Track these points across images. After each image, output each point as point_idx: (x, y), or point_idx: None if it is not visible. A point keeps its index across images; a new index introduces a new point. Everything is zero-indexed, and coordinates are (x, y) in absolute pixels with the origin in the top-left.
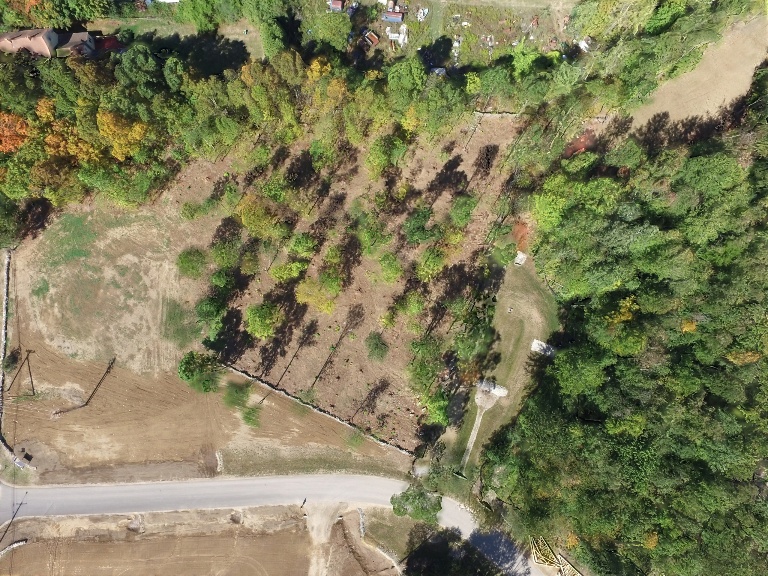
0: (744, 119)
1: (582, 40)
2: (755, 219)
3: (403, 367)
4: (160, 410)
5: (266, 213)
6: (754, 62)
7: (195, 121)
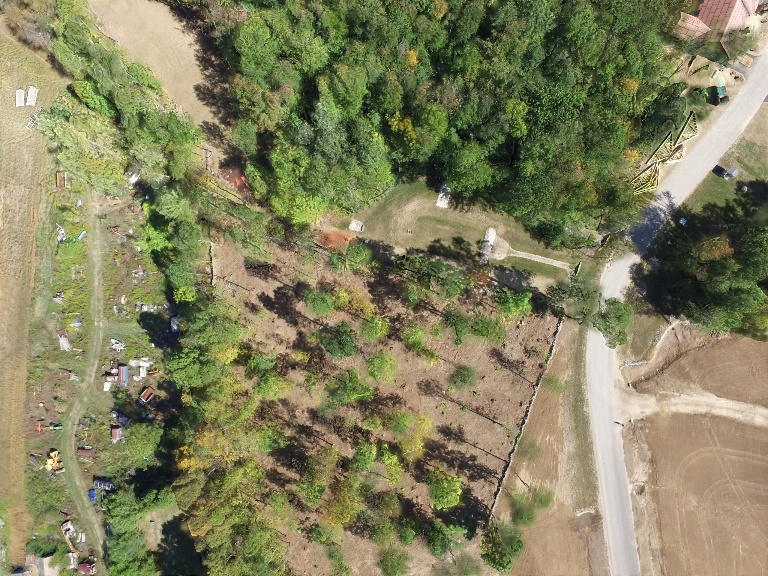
0: (193, 7)
1: (129, 181)
2: (298, 1)
3: (476, 336)
4: (540, 575)
5: (338, 500)
6: (134, 0)
7: (250, 572)
